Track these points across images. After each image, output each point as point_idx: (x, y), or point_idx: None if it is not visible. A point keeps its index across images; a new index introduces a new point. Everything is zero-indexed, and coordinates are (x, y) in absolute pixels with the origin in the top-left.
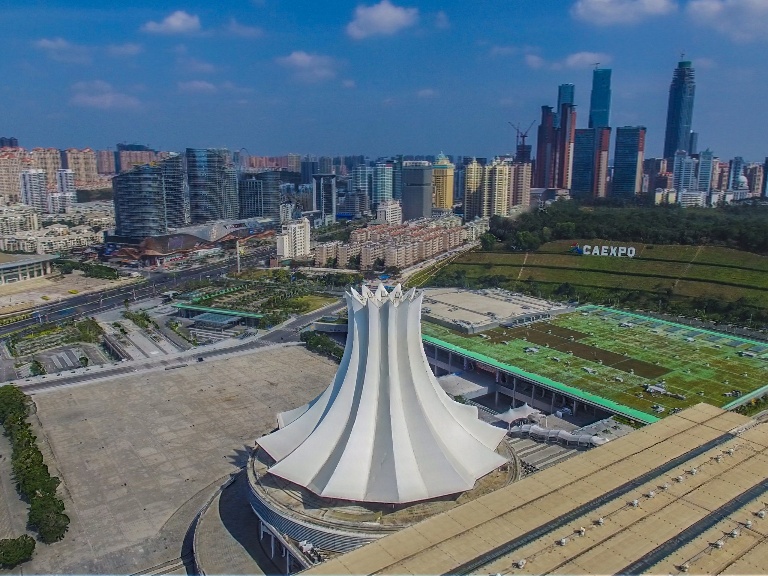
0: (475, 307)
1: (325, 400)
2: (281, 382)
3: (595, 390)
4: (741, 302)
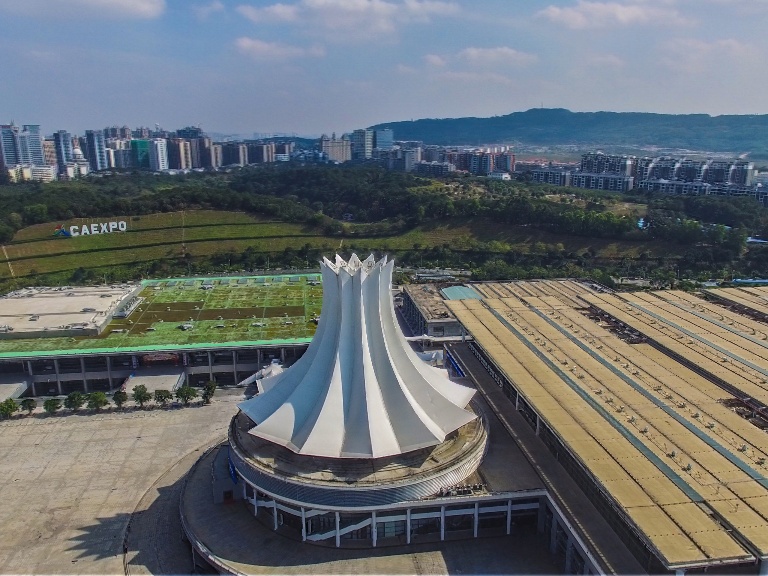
0: (53, 309)
1: (337, 382)
2: None
3: (292, 335)
4: (251, 251)
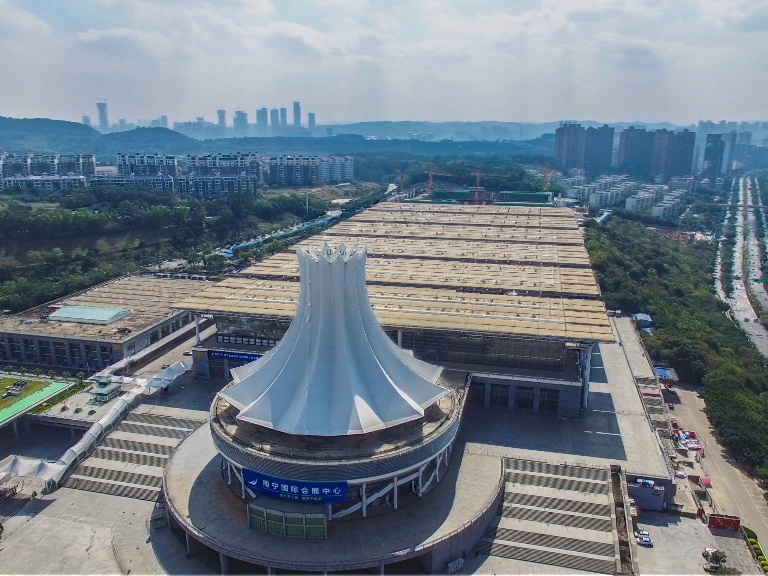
0: None
1: None
2: None
3: None
4: None
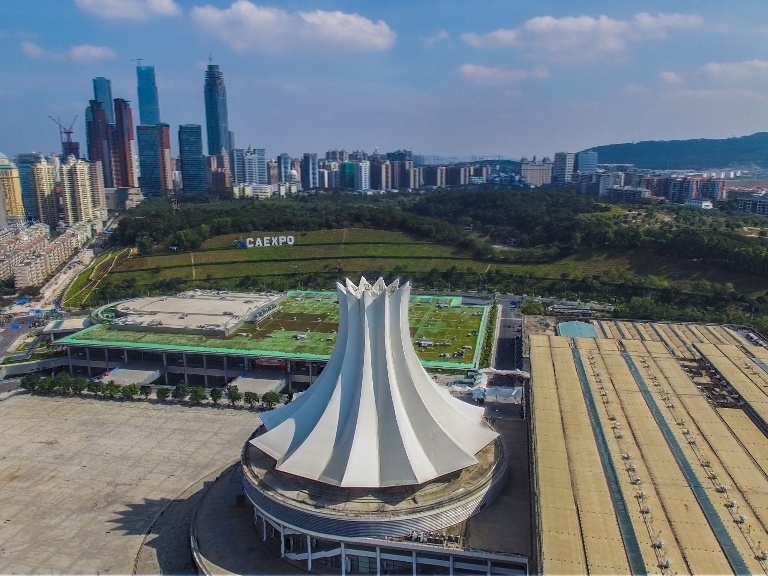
0: (202, 310)
1: (335, 404)
2: (58, 438)
3: None
4: (398, 270)
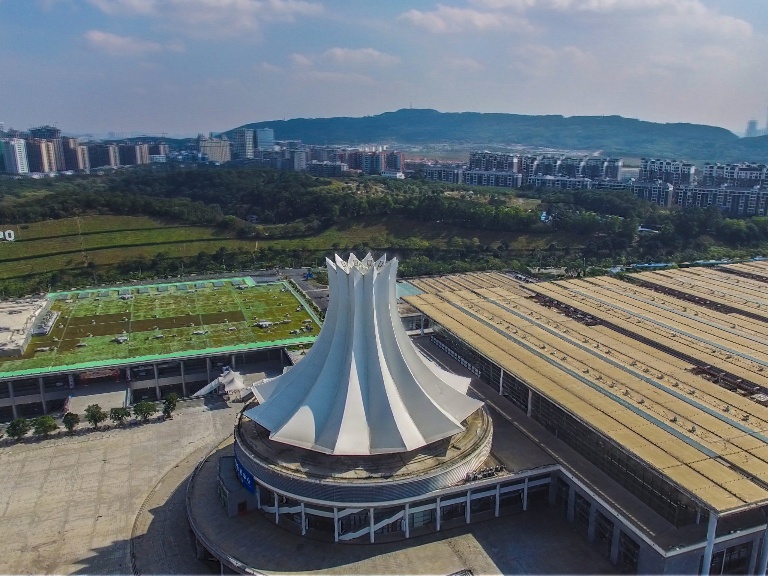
0: None
1: (355, 381)
2: None
3: (241, 341)
4: (161, 257)
